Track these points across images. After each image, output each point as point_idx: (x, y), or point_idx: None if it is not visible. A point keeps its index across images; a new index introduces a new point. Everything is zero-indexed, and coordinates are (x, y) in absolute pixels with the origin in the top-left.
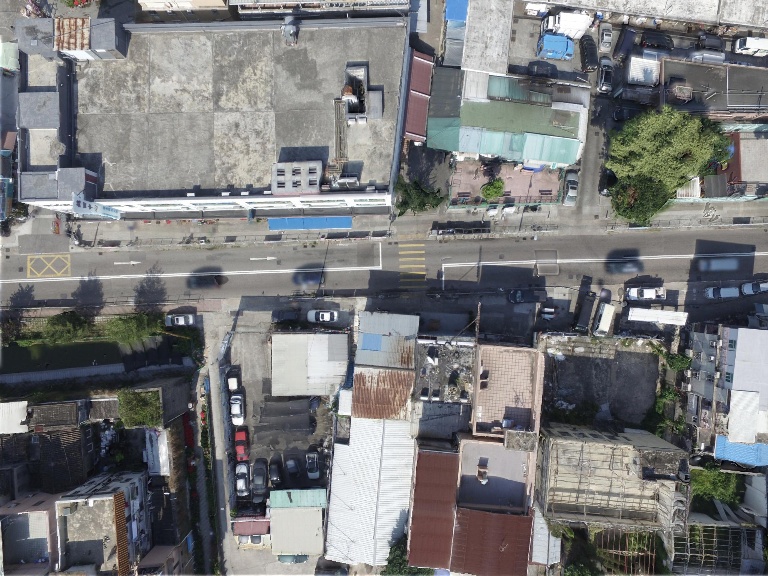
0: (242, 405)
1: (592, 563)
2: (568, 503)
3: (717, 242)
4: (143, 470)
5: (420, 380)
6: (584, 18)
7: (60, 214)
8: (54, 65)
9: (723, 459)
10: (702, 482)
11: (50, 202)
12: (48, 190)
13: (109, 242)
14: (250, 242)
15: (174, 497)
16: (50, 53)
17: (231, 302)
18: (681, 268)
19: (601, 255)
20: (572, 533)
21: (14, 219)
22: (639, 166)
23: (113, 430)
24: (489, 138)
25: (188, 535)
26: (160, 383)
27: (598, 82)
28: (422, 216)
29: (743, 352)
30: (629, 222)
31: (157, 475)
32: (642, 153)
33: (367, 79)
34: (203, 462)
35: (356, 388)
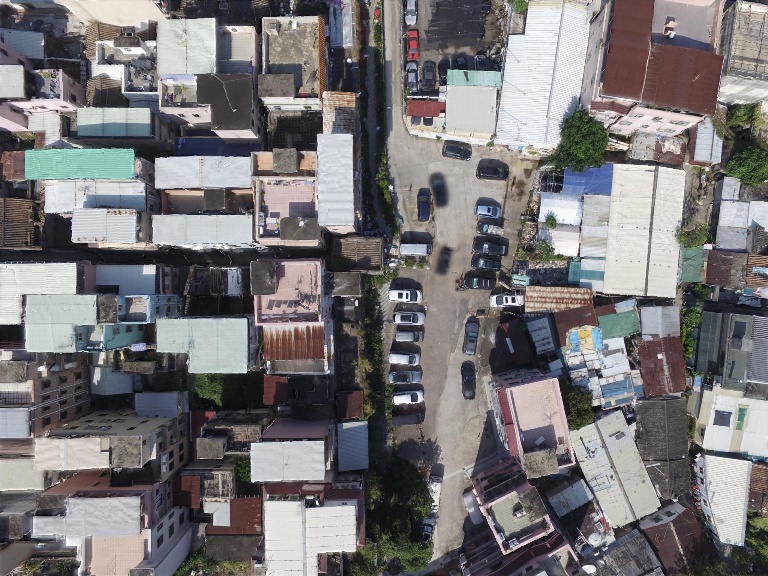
0: (416, 5)
1: None
2: (747, 72)
3: None
4: None
5: None
6: None
7: None
8: None
9: None
10: None
11: None
12: None
13: None
14: None
15: (356, 66)
16: None
17: None
18: None
19: None
20: None
21: None
22: None
23: (292, 15)
24: None
25: None
26: None
27: None
28: None
29: None
30: None
31: (339, 48)
32: None
33: None
34: (374, 59)
35: None
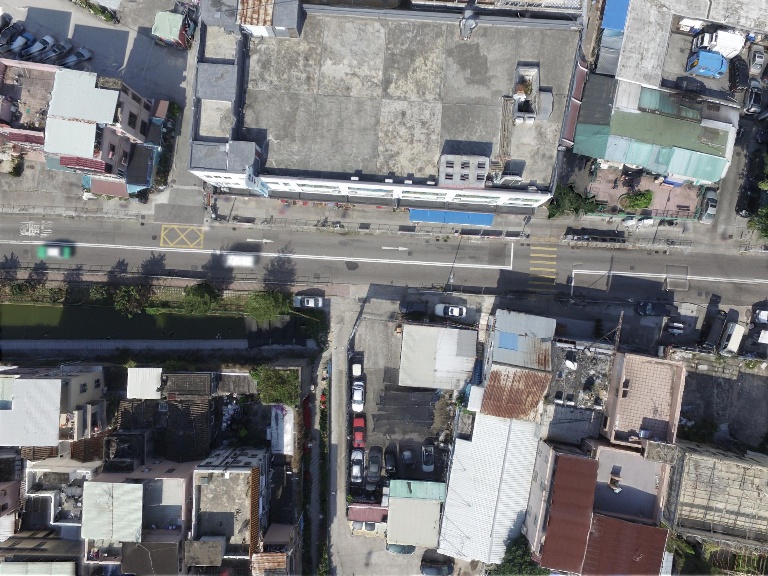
0: (363, 392)
1: None
2: (695, 519)
3: None
4: (263, 447)
5: (555, 383)
6: (738, 38)
7: (210, 186)
8: (231, 38)
9: None
10: None
11: (217, 173)
12: (217, 161)
13: (244, 218)
14: (384, 231)
15: (296, 477)
16: (232, 26)
17: (359, 289)
18: None
19: (732, 275)
20: (692, 549)
21: (153, 187)
22: None
23: (236, 405)
24: (636, 149)
25: (301, 516)
26: (293, 362)
27: (746, 103)
28: (557, 220)
29: None
30: (764, 245)
31: (280, 453)
32: None
33: (539, 79)
34: (319, 445)
35: (490, 385)
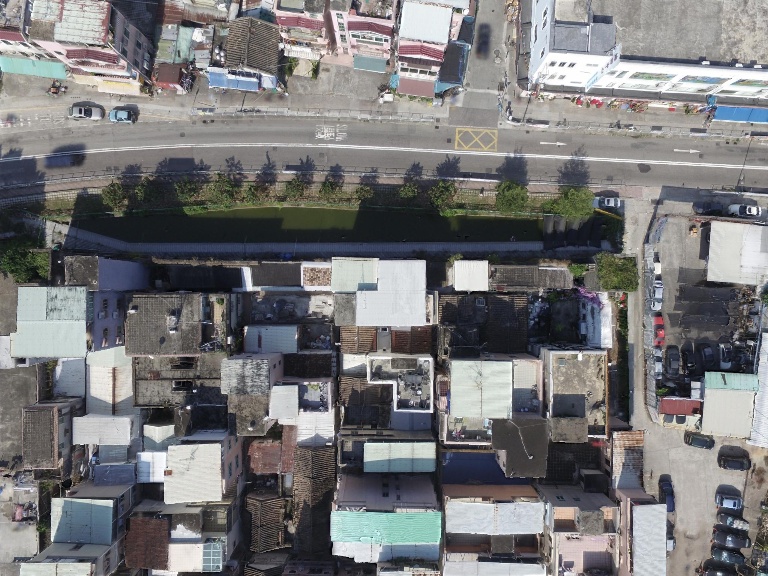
0: None
1: None
2: None
3: None
4: None
5: None
6: None
7: (532, 81)
8: None
9: None
10: None
11: (574, 57)
12: (578, 43)
13: (538, 121)
14: (676, 133)
15: (615, 369)
16: None
17: (652, 191)
18: None
19: None
20: None
21: (449, 90)
22: None
23: (541, 303)
24: None
25: None
26: None
27: None
28: None
29: None
30: None
31: (596, 347)
32: None
33: None
34: None
35: None
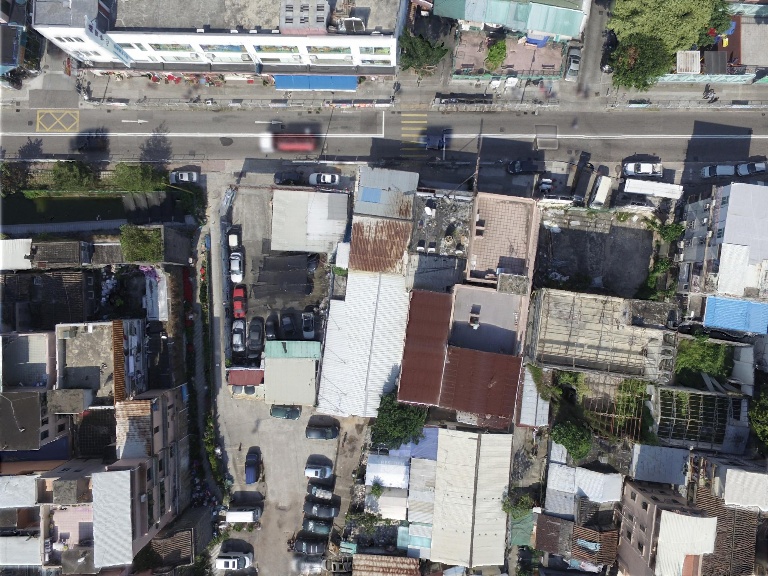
0: (241, 263)
1: (579, 421)
2: (558, 355)
3: (715, 124)
4: (142, 318)
5: (417, 232)
6: None
7: (71, 58)
8: None
9: (712, 328)
10: (691, 354)
11: (63, 31)
12: (61, 17)
13: (118, 100)
14: (256, 105)
15: (171, 341)
16: None
17: (235, 163)
18: (679, 148)
19: (600, 132)
20: (560, 390)
21: (26, 73)
22: (640, 22)
23: (114, 280)
24: (495, 7)
25: (183, 385)
26: None
27: None
28: (426, 87)
29: (735, 206)
30: (629, 99)
31: (155, 321)
32: (644, 9)
33: None
34: (201, 317)
35: (354, 238)
